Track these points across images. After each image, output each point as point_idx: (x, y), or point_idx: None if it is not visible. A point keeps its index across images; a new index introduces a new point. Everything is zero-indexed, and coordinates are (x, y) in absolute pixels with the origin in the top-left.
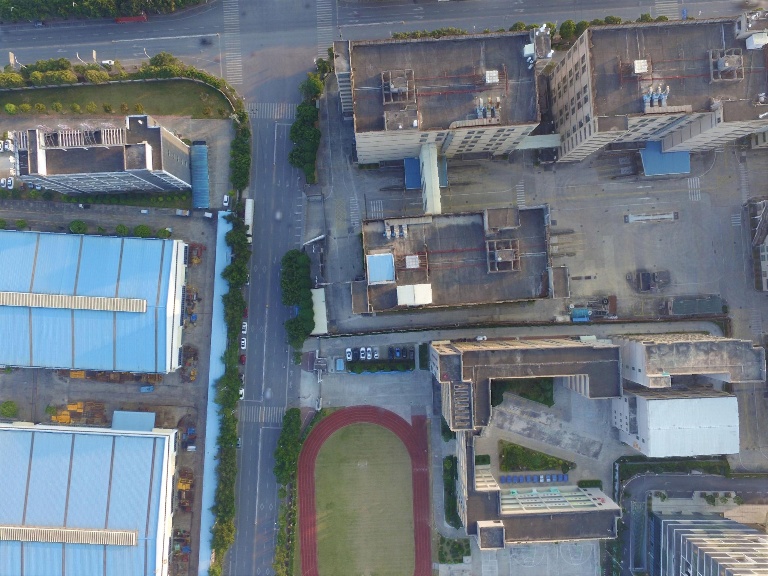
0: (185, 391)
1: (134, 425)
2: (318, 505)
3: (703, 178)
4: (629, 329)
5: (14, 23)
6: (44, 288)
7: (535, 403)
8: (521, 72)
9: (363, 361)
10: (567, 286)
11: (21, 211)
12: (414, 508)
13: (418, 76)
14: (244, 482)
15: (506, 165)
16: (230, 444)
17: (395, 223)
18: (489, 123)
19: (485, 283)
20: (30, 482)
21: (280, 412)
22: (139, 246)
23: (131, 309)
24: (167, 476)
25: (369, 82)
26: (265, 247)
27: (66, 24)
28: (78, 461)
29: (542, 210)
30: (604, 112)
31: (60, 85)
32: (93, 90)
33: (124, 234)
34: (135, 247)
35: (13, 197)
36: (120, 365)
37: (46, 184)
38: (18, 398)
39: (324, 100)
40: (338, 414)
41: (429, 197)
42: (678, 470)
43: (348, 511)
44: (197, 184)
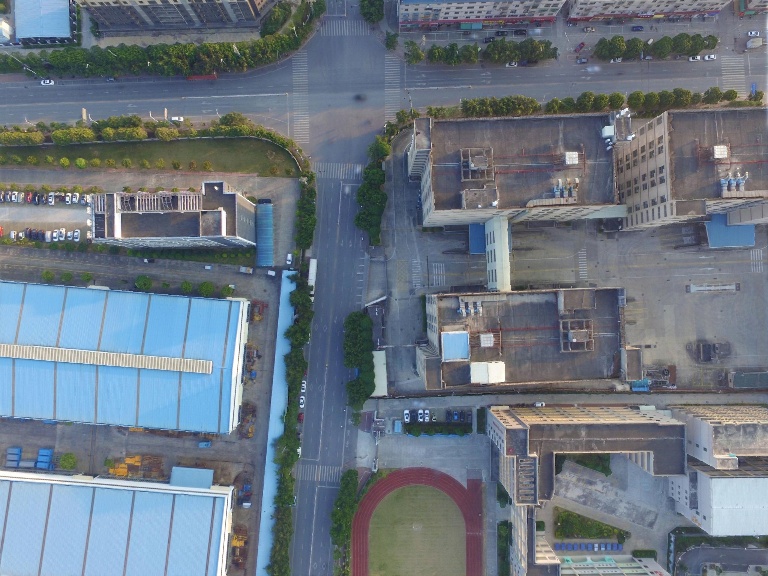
0: (242, 447)
1: (192, 482)
2: (371, 566)
3: (766, 250)
4: (688, 399)
5: (86, 77)
6: (112, 346)
7: (591, 471)
8: (599, 152)
9: (421, 423)
10: (640, 369)
11: (86, 263)
12: (467, 572)
13: (496, 154)
14: (298, 540)
15: (569, 231)
16: (287, 504)
17: (470, 300)
18: (566, 203)
19: (557, 362)
20: (90, 538)
21: (336, 471)
22: (206, 306)
23: (197, 370)
24: (224, 535)
25: (447, 158)
26: (326, 306)
27: (137, 79)
28: (138, 518)
29: (616, 290)
30: (681, 194)
31: (129, 140)
32: (161, 145)
33: (189, 291)
34: (202, 307)
35: (80, 251)
36: (183, 424)
37: (117, 243)
38: (77, 449)
39: (390, 162)
40: (394, 475)
41: (499, 269)
42: (734, 543)
43: (401, 573)
44: (262, 243)
